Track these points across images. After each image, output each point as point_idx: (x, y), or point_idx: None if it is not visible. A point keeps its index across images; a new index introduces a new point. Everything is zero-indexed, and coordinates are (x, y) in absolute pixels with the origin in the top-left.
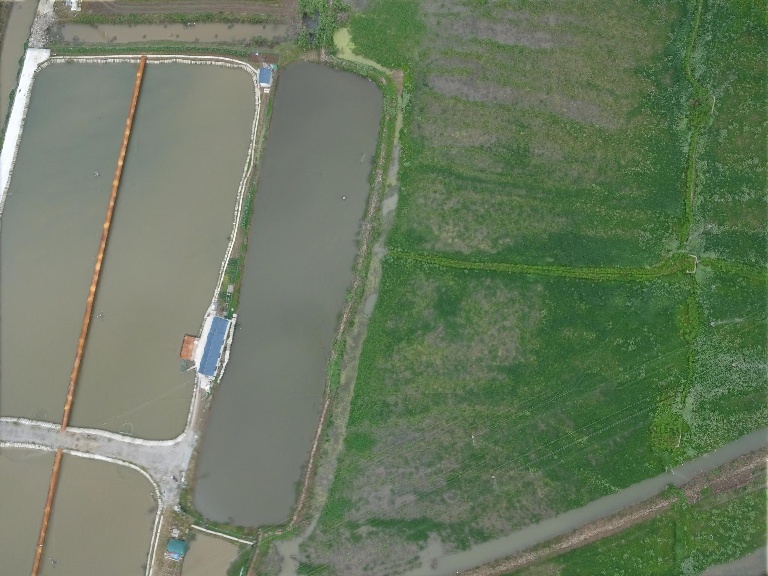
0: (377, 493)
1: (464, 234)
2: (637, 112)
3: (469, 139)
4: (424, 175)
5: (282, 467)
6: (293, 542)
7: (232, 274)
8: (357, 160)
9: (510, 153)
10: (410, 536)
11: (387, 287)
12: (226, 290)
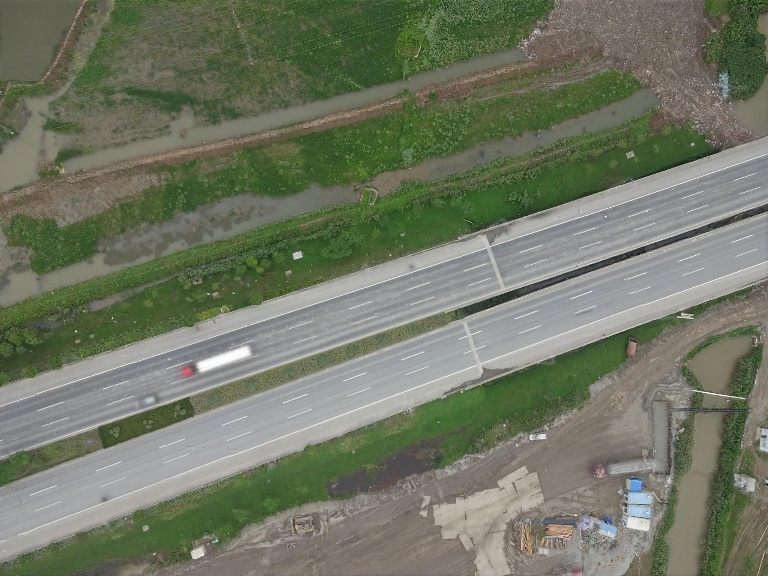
0: (137, 65)
1: None
2: None
3: None
4: None
5: (43, 30)
6: (44, 100)
7: None
8: None
9: None
10: (164, 105)
11: None
12: None
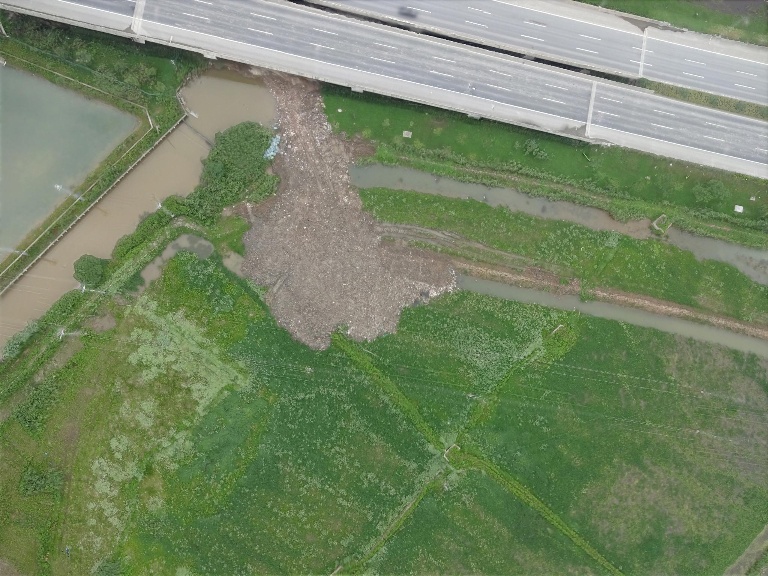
0: None
1: None
2: None
3: None
4: None
5: None
6: None
7: None
8: None
9: None
10: None
11: None
12: None
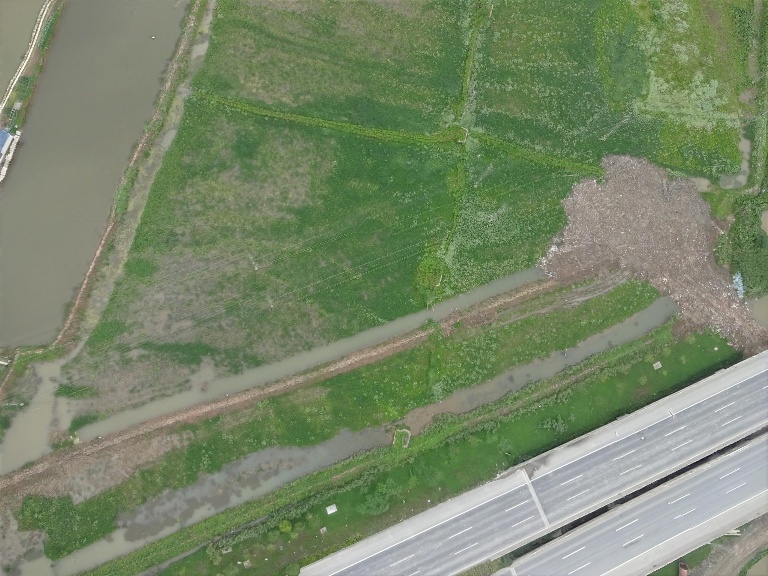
0: (153, 317)
1: (268, 86)
2: (431, 7)
3: (282, 4)
4: (236, 28)
5: (52, 289)
6: (55, 364)
7: (21, 92)
8: (171, 5)
9: (318, 22)
10: (183, 359)
11: (187, 124)
12: (12, 107)
